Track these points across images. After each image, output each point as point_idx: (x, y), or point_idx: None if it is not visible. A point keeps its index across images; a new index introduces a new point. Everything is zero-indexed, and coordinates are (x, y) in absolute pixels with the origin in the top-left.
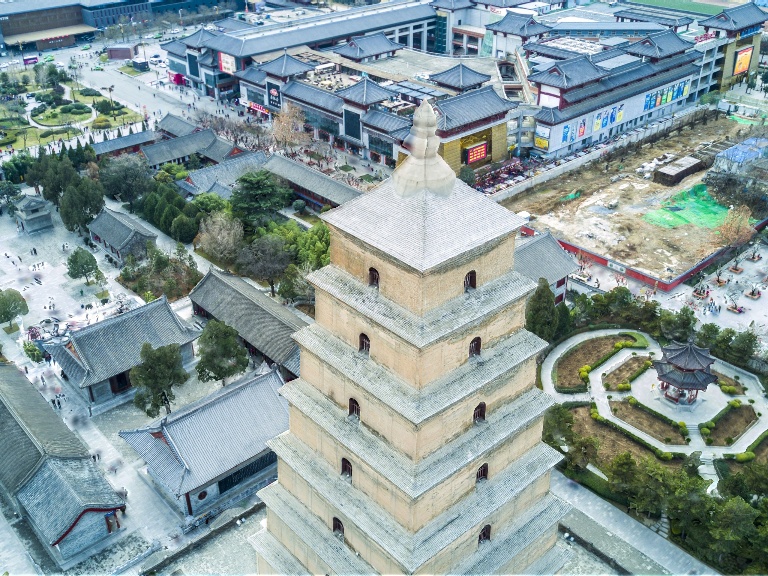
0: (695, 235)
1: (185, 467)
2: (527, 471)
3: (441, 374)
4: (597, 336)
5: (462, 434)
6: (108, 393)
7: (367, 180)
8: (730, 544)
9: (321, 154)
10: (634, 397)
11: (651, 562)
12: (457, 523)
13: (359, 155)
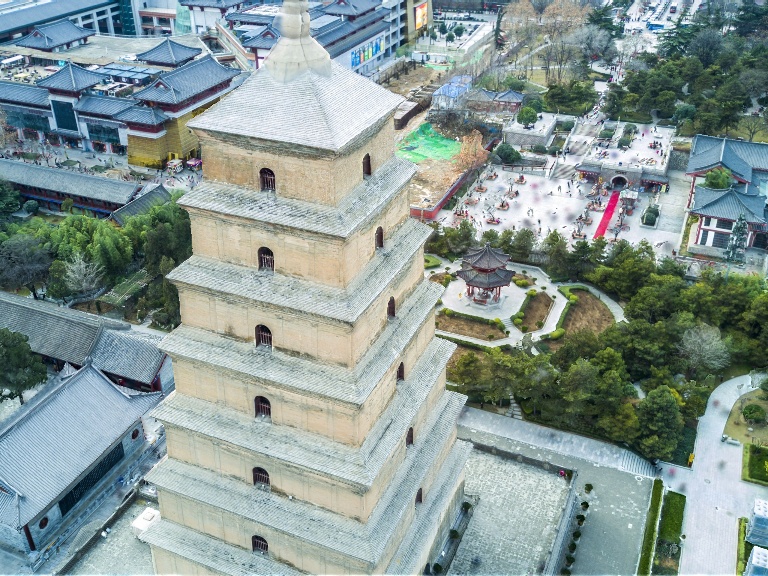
0: (437, 167)
1: (17, 495)
2: (433, 365)
3: (358, 269)
4: None
5: (381, 333)
6: None
7: None
8: (580, 404)
9: (37, 152)
10: (448, 308)
11: (518, 443)
12: (393, 428)
13: (79, 148)
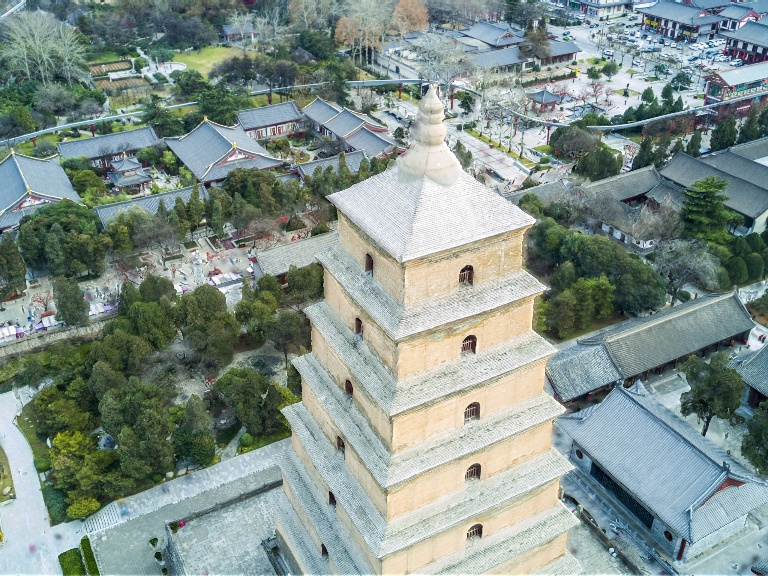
0: None
1: (583, 417)
2: None
3: None
4: None
5: None
6: (744, 397)
7: None
8: None
9: None
10: None
11: None
12: None
13: None
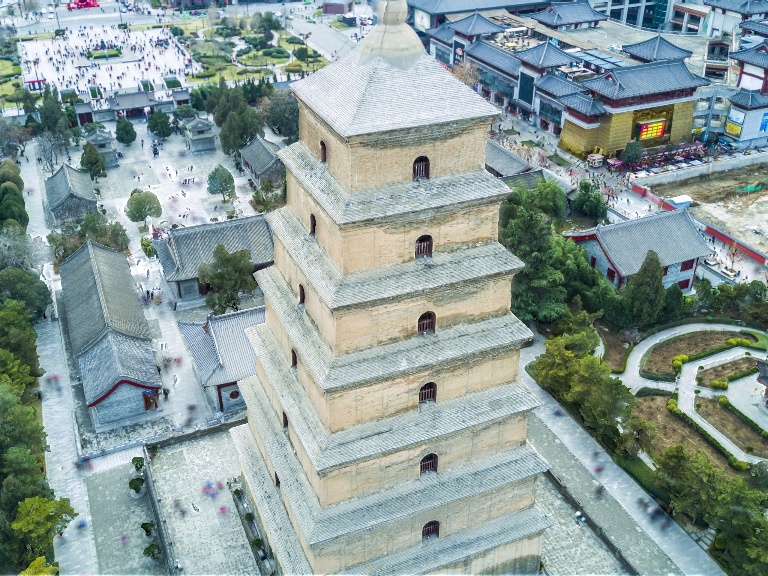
0: None
1: (219, 362)
2: (489, 407)
3: (375, 265)
4: (712, 329)
5: (401, 341)
6: (195, 293)
7: (528, 146)
8: None
9: None
10: (727, 397)
11: (676, 569)
12: (385, 437)
13: (529, 121)
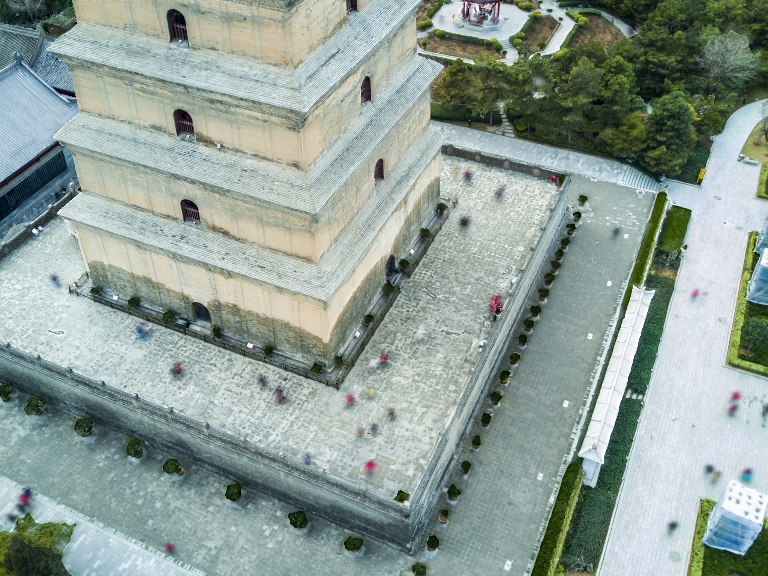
0: None
1: None
2: (396, 4)
3: None
4: None
5: None
6: None
7: None
8: None
9: None
10: (439, 29)
11: None
12: (339, 58)
13: None
